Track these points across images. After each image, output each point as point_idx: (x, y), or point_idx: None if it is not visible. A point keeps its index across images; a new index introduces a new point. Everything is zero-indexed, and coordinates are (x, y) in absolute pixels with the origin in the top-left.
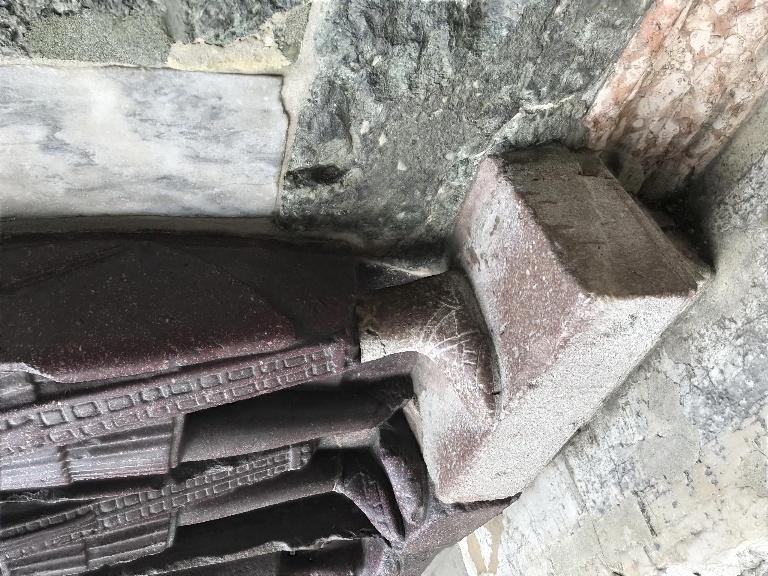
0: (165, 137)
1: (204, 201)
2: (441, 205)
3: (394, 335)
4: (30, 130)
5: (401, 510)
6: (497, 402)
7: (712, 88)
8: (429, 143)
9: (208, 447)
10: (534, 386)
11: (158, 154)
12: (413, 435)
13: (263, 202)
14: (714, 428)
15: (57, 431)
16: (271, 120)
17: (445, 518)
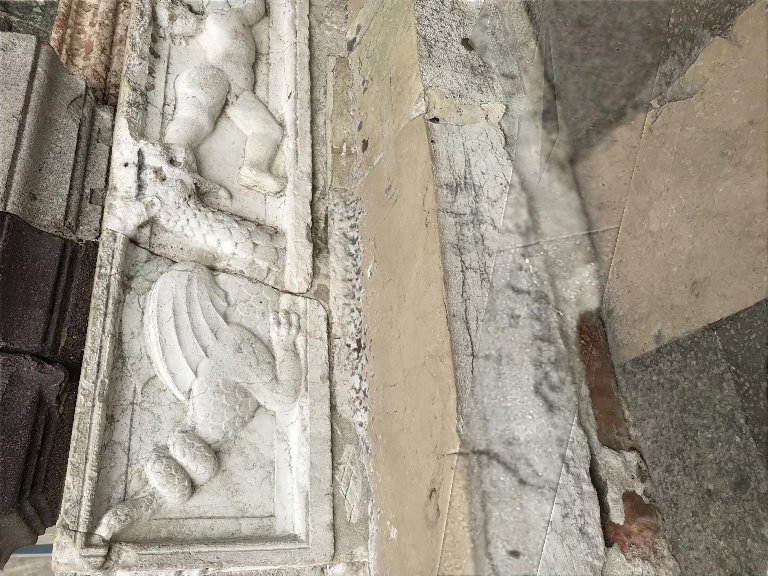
0: None
1: None
2: None
3: None
4: None
5: None
6: None
7: (94, 74)
8: None
9: None
10: None
11: None
12: None
13: None
14: None
15: None
16: None
17: None
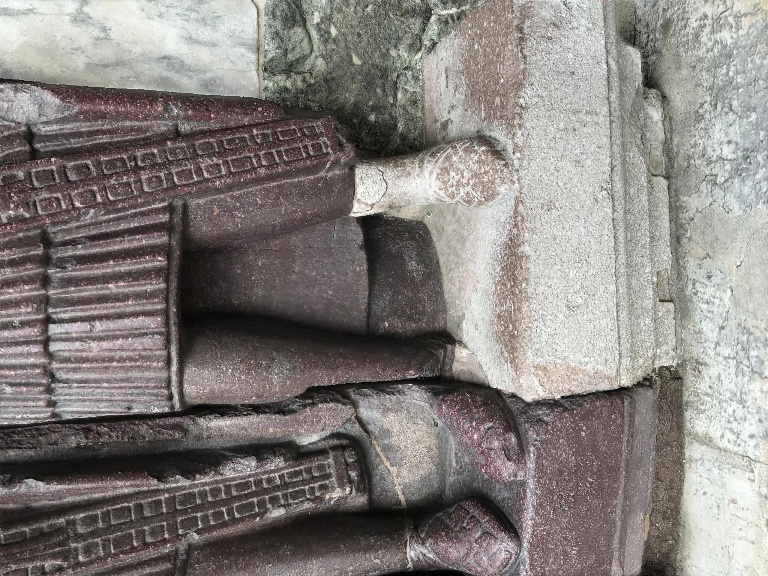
0: (165, 18)
1: (198, 87)
2: (404, 110)
3: (389, 164)
4: (65, 3)
5: (489, 458)
6: (505, 156)
7: None
8: (372, 38)
9: (217, 351)
10: (526, 108)
11: (159, 33)
12: (473, 383)
13: (248, 93)
14: (765, 185)
15: (45, 194)
16: (244, 8)
17: (546, 430)
